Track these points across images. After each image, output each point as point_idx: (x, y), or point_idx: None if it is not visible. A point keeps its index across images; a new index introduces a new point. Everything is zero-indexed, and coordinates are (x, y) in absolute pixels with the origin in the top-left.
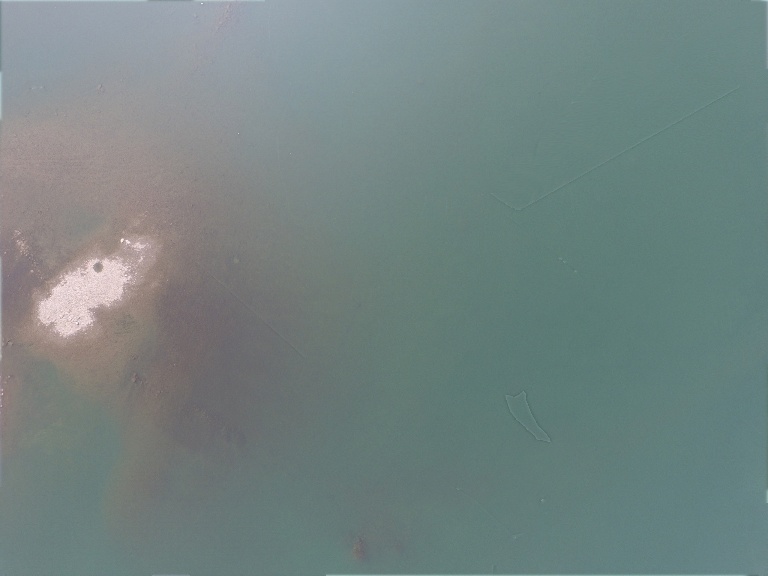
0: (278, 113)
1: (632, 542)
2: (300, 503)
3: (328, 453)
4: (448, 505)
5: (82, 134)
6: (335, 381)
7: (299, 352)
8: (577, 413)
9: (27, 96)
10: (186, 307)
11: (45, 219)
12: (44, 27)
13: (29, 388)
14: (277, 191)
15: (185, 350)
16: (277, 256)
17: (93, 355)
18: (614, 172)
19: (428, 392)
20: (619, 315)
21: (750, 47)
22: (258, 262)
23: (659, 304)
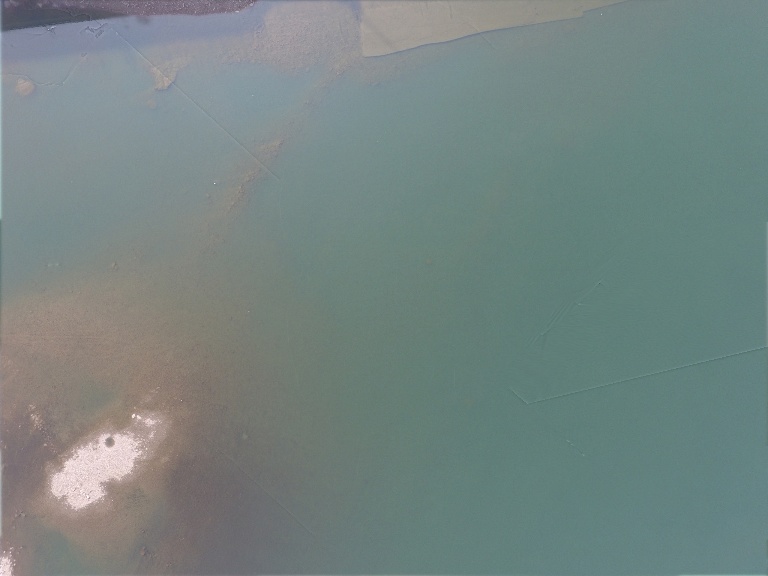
0: (288, 291)
1: None
2: None
3: None
4: None
5: (96, 311)
6: (341, 550)
7: (306, 528)
8: None
9: (43, 273)
10: (195, 482)
11: (59, 394)
12: (61, 202)
13: (41, 559)
14: (286, 368)
15: (194, 524)
16: (285, 432)
17: (103, 528)
18: None
19: (434, 560)
20: (627, 494)
21: (761, 303)
22: (267, 438)
23: (668, 479)
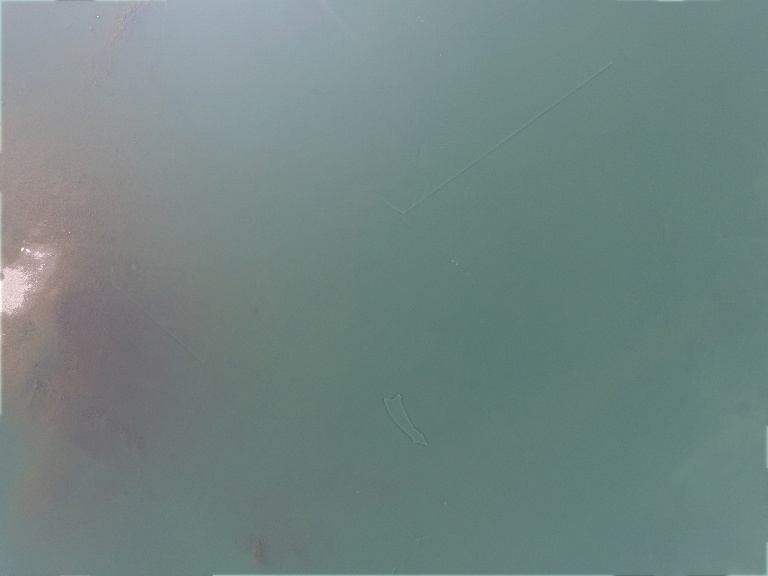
0: (173, 122)
1: (530, 545)
2: (198, 507)
3: (228, 457)
4: (352, 508)
5: None
6: (237, 385)
7: (196, 357)
8: (476, 415)
9: None
10: (85, 314)
11: None
12: None
13: None
14: (173, 198)
15: (85, 356)
16: (174, 262)
17: None
18: (509, 174)
19: (331, 395)
20: (516, 317)
21: (592, 48)
22: (156, 269)
23: (559, 305)
